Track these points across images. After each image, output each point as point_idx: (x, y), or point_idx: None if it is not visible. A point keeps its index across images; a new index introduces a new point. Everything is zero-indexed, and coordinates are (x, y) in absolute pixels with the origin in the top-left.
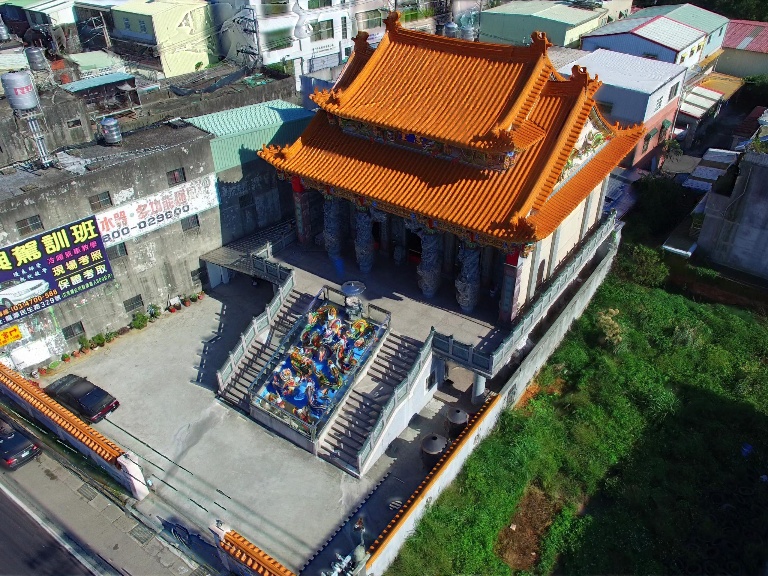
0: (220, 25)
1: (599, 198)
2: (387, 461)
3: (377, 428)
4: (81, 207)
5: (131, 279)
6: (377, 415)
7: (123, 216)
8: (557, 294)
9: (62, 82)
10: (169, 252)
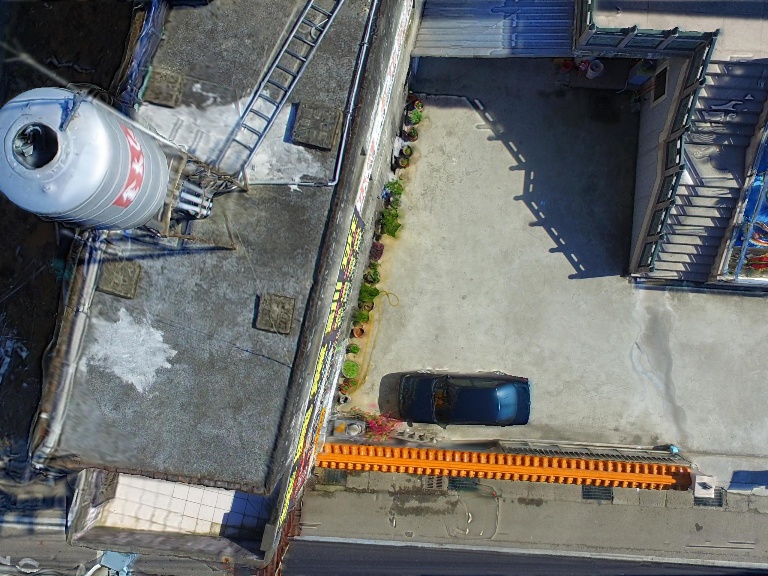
0: None
1: None
2: None
3: None
4: None
5: (373, 197)
6: None
7: None
8: None
9: None
10: None
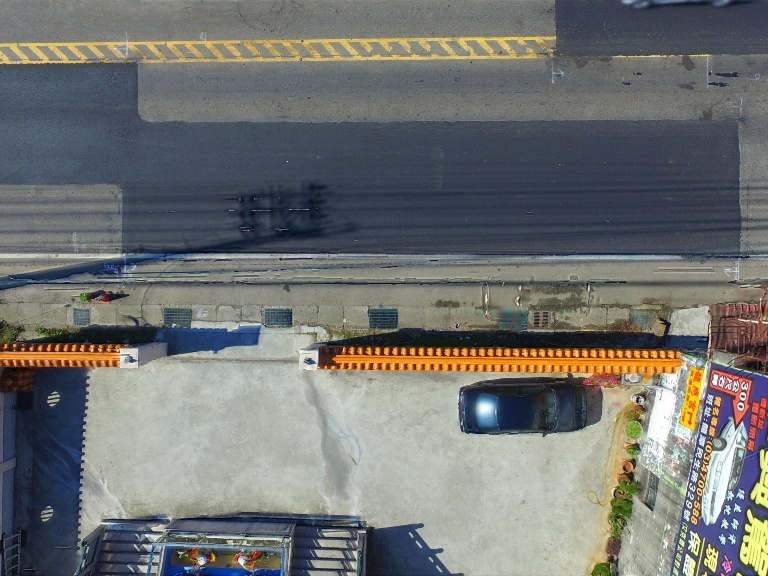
0: None
1: None
2: None
3: None
4: None
5: None
6: None
7: None
8: None
9: None
10: None
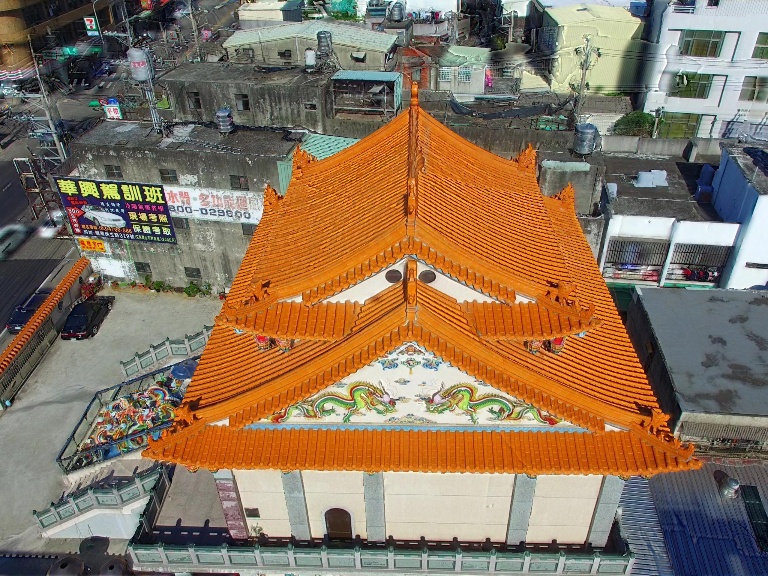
0: (556, 50)
1: (593, 511)
2: (73, 546)
3: (64, 507)
4: (153, 174)
5: (192, 252)
6: None
7: (188, 196)
8: (354, 569)
9: (421, 69)
10: (229, 246)
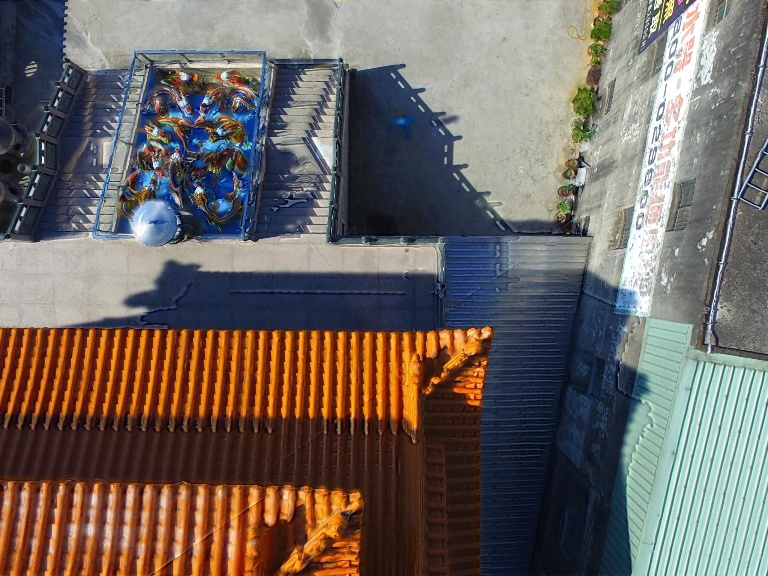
0: None
1: None
2: None
3: None
4: None
5: None
6: (81, 126)
7: None
8: None
9: None
10: None
